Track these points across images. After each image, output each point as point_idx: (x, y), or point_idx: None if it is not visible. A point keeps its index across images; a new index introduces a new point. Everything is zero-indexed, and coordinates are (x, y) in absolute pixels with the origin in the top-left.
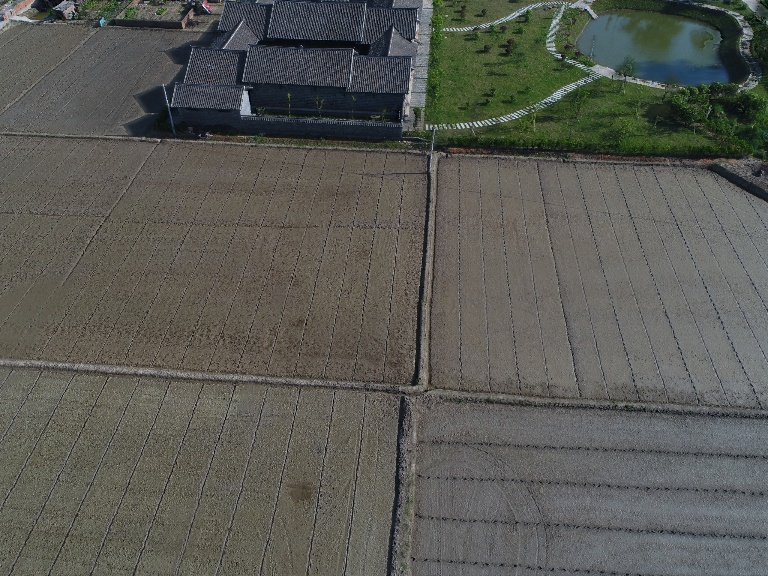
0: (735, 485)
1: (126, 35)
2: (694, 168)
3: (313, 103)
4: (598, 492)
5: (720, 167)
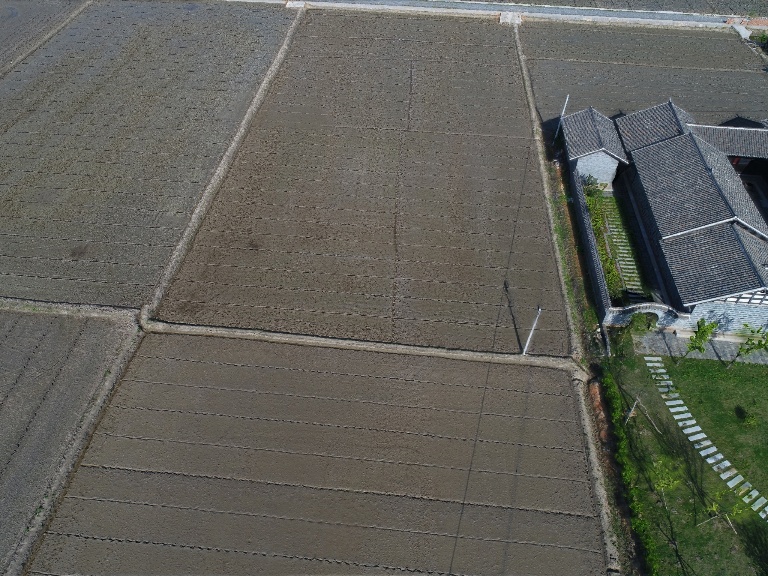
0: None
1: (761, 89)
2: None
3: (652, 230)
4: None
5: None
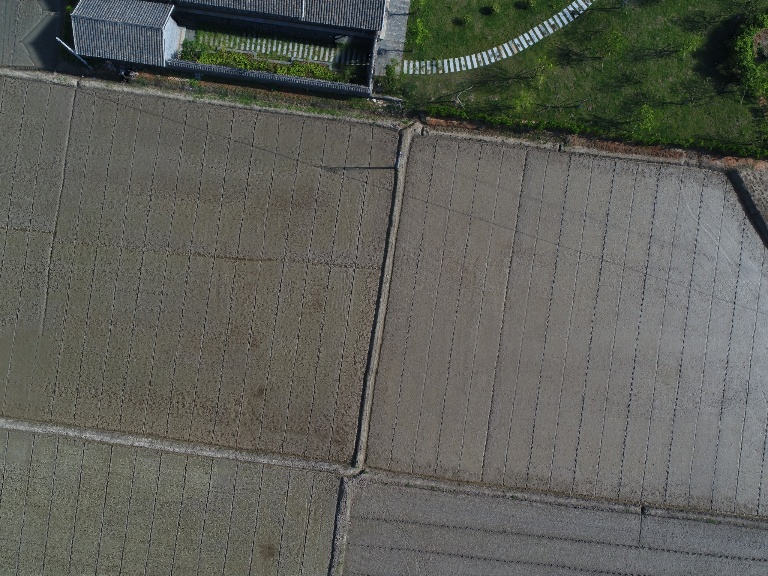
0: (566, 562)
1: None
2: (710, 170)
3: (258, 13)
4: (469, 562)
5: (739, 177)
